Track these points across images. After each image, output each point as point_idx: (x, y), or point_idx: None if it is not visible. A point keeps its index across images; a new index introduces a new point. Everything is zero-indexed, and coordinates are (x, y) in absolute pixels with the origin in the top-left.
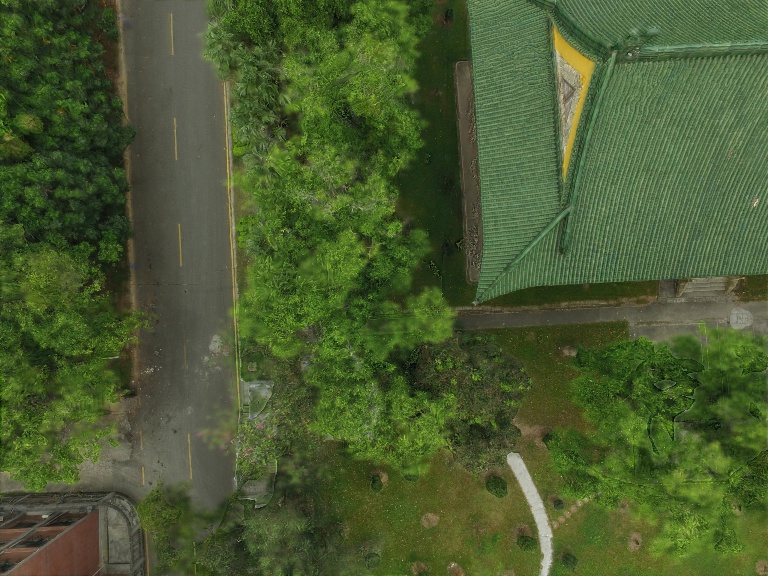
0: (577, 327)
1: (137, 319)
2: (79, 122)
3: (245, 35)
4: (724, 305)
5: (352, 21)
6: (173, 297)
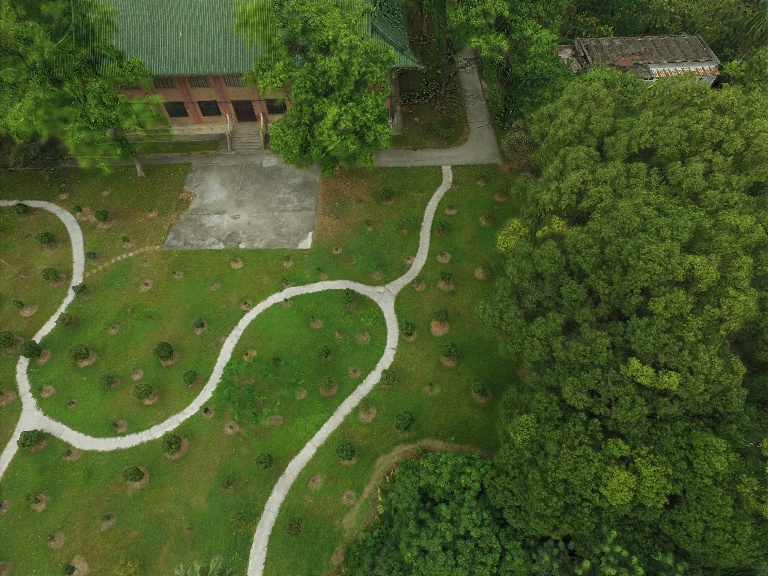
0: (155, 165)
1: None
2: None
3: None
4: (260, 155)
5: None
6: None
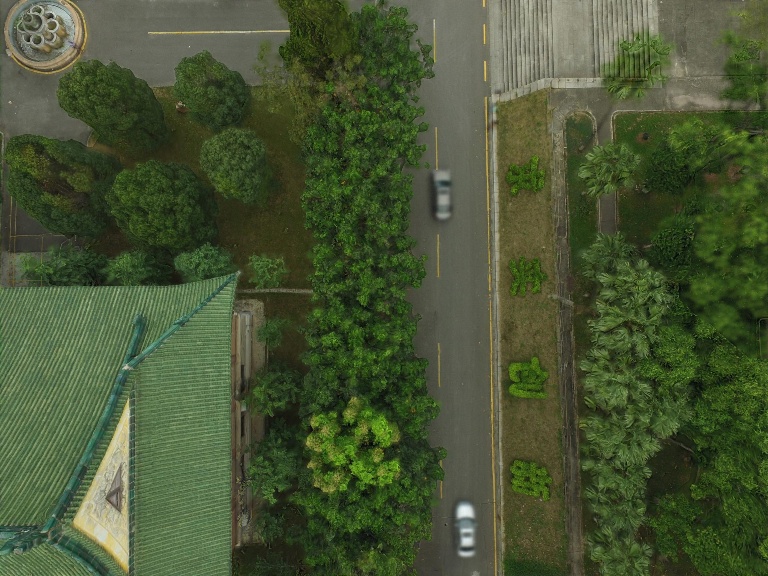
0: None
1: None
2: (421, 417)
3: None
4: None
5: None
6: (433, 530)
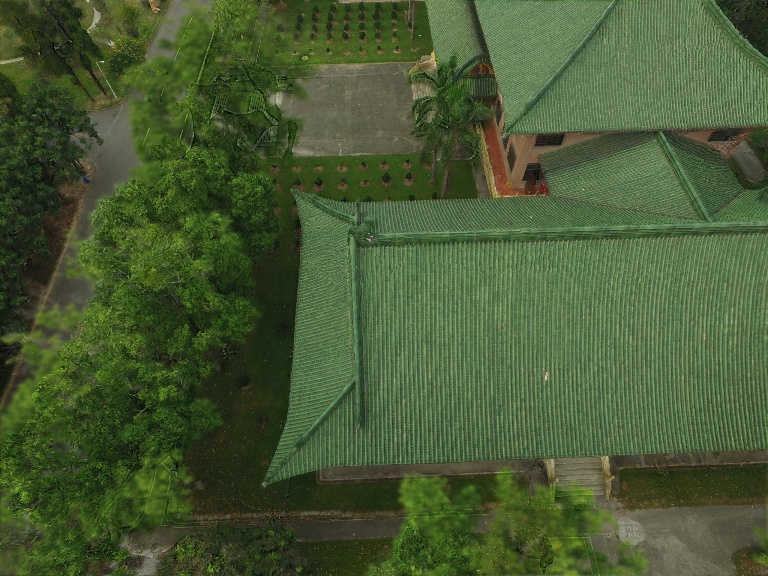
0: None
1: None
2: None
3: (111, 242)
4: (608, 514)
5: (182, 228)
6: None
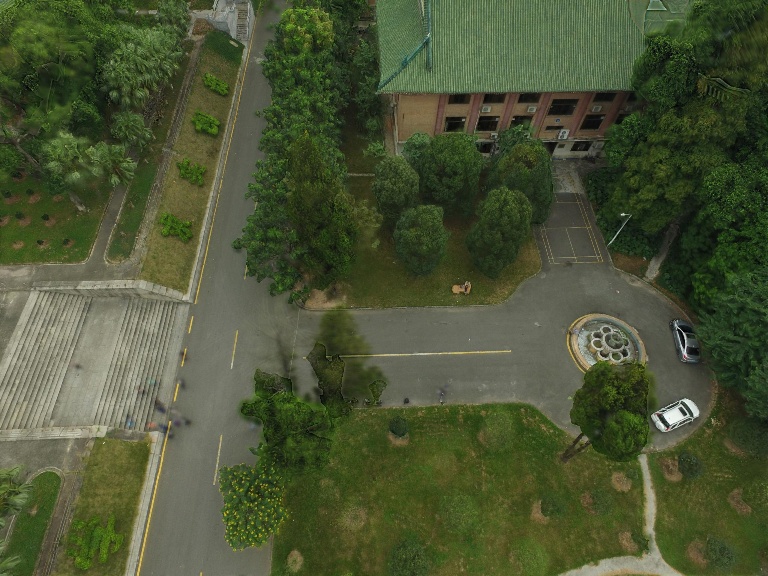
0: None
1: (260, 8)
2: None
3: None
4: None
5: None
6: None
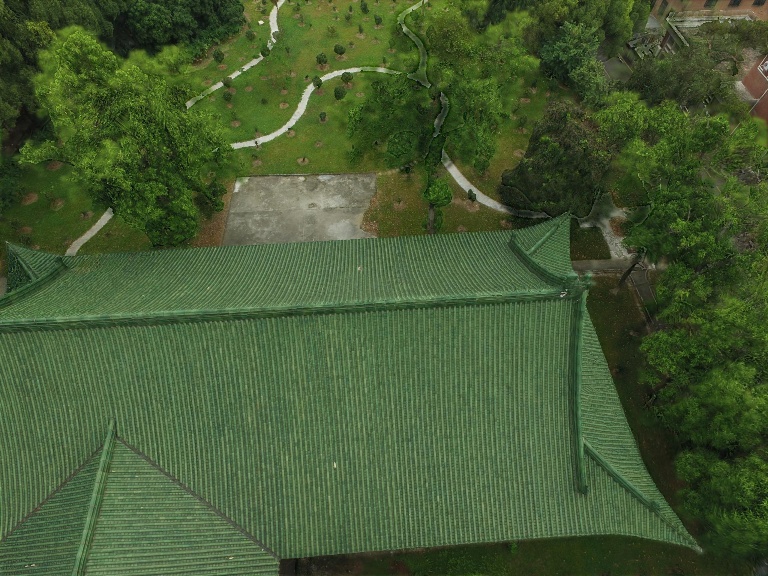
0: None
1: None
2: None
3: None
4: None
5: None
6: None
